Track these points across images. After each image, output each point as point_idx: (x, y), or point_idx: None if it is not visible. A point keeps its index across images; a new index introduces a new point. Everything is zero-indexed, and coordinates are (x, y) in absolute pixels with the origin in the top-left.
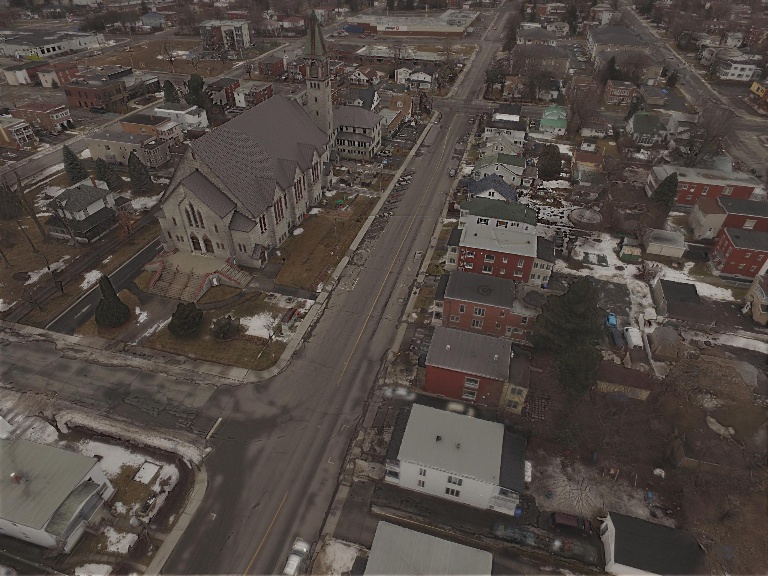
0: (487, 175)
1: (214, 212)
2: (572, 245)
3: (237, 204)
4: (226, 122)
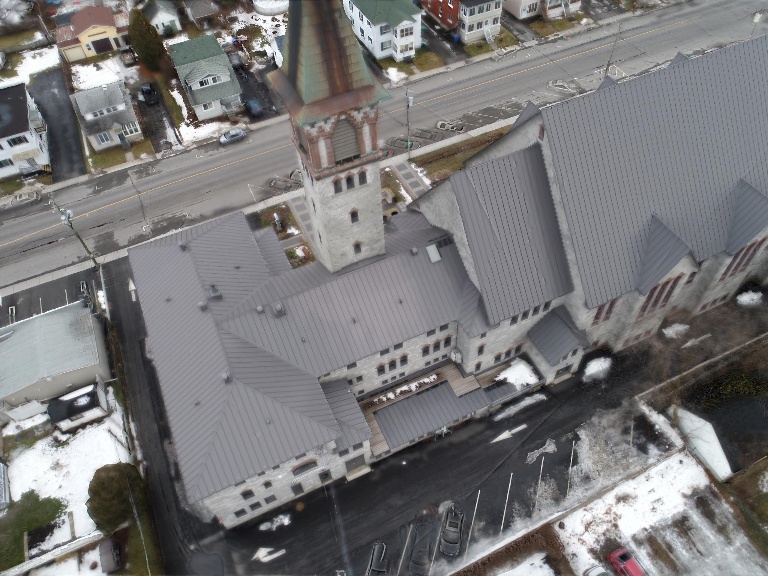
0: None
1: None
2: None
3: None
4: None
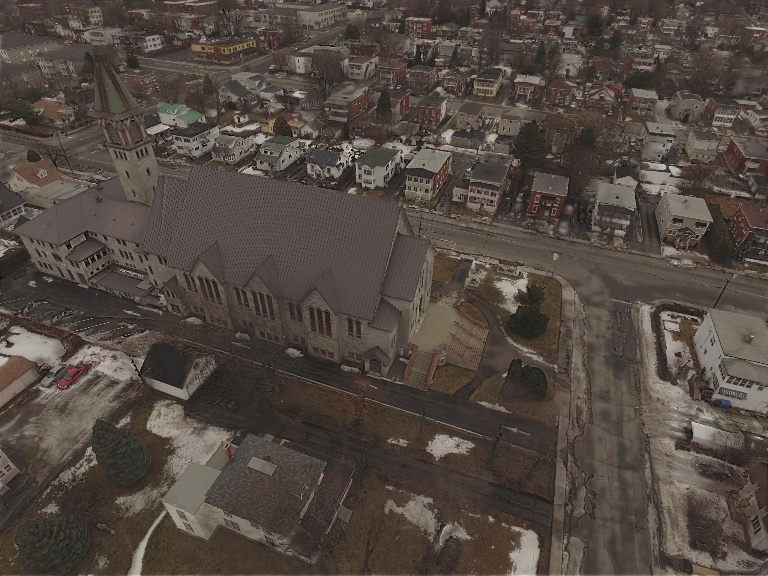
0: (283, 161)
1: (433, 254)
2: (420, 147)
3: None
4: None
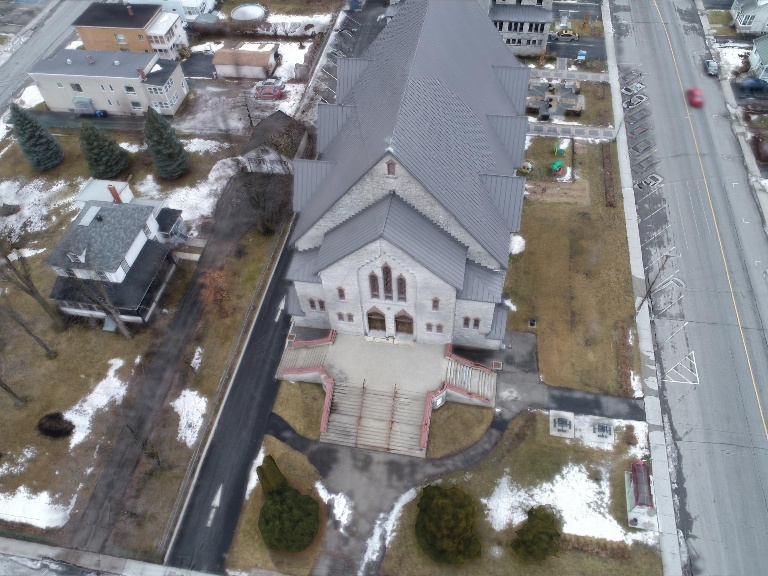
0: None
1: (442, 281)
2: None
3: (468, 247)
4: (411, 64)
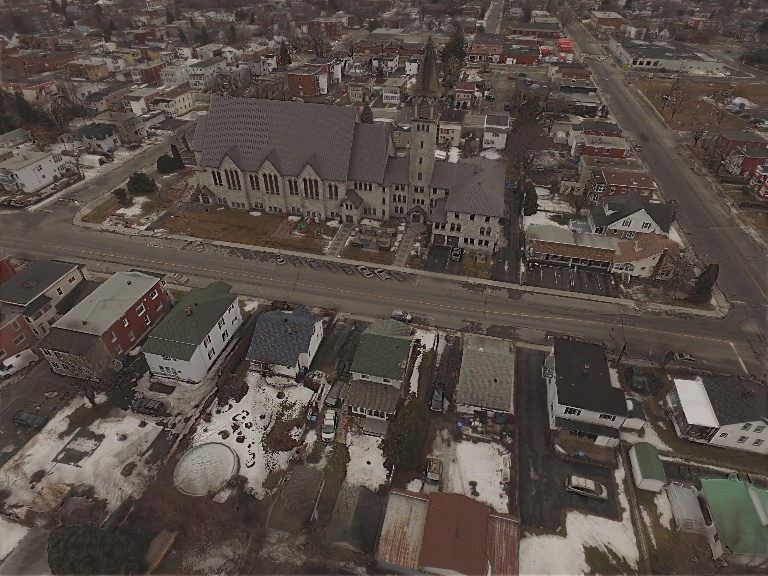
0: None
1: None
2: None
3: None
4: None
